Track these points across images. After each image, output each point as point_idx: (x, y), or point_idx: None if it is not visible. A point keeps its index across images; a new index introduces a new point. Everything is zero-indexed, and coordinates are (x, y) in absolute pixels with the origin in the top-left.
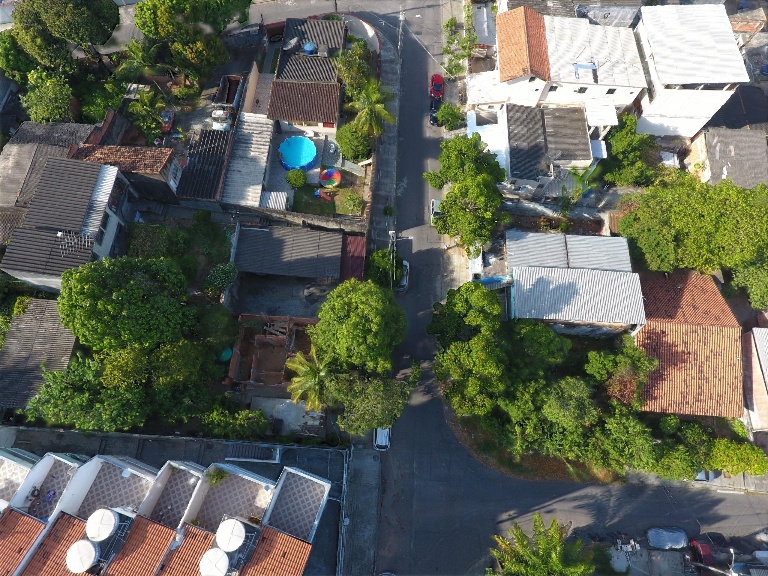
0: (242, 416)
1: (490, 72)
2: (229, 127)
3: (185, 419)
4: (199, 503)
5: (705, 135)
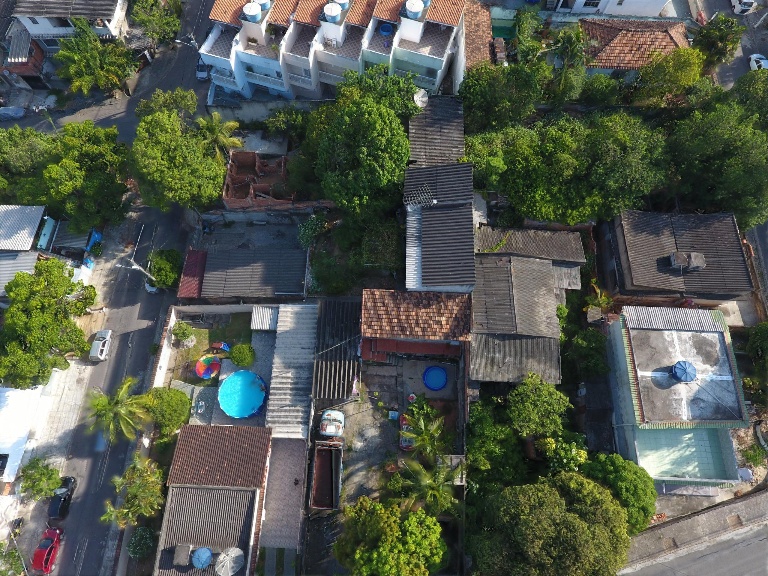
0: (280, 119)
1: None
2: None
3: None
4: (290, 47)
5: None
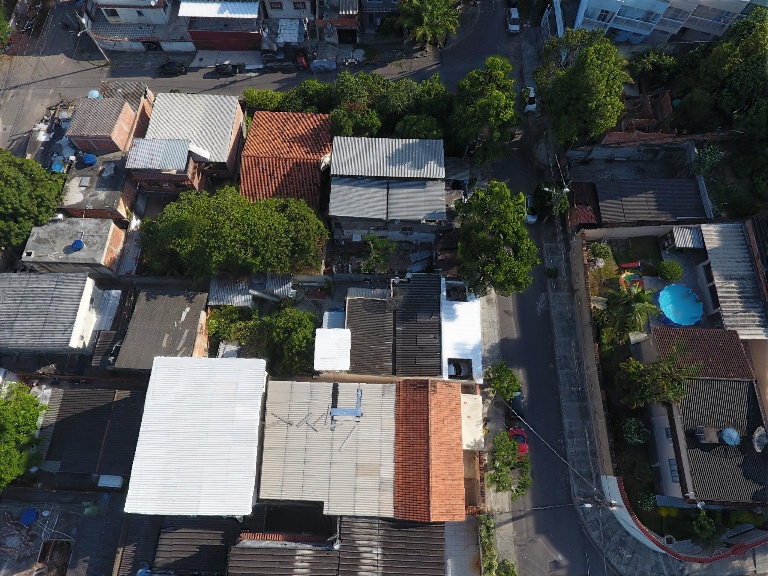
0: (651, 60)
1: None
2: None
3: None
4: None
5: None
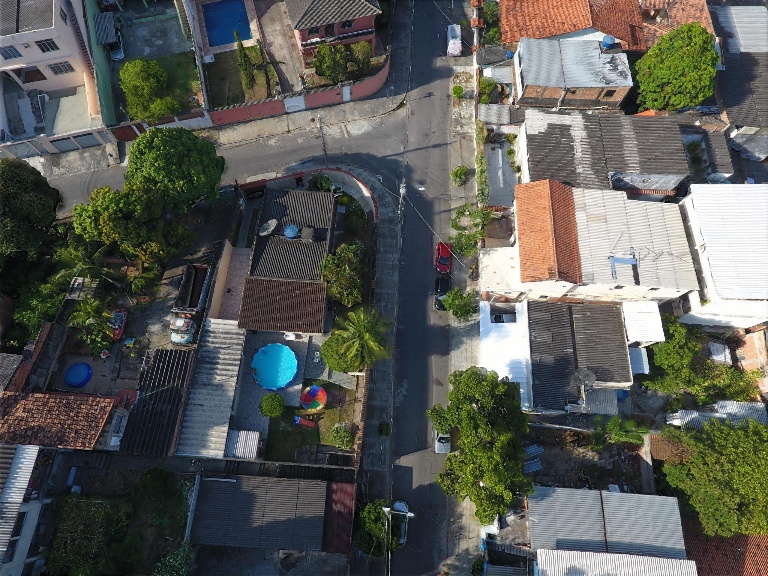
0: None
1: (507, 249)
2: (192, 337)
3: None
4: None
5: (765, 334)
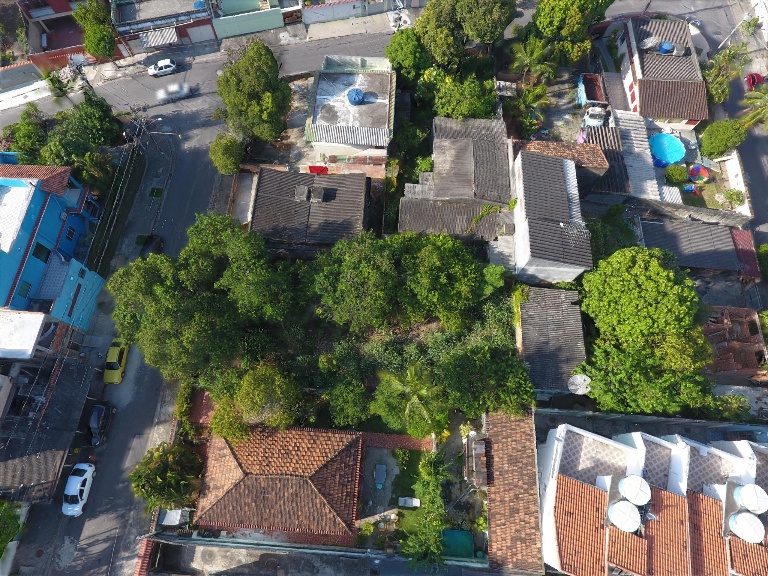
0: (735, 400)
1: None
2: None
3: (691, 403)
4: None
5: None
